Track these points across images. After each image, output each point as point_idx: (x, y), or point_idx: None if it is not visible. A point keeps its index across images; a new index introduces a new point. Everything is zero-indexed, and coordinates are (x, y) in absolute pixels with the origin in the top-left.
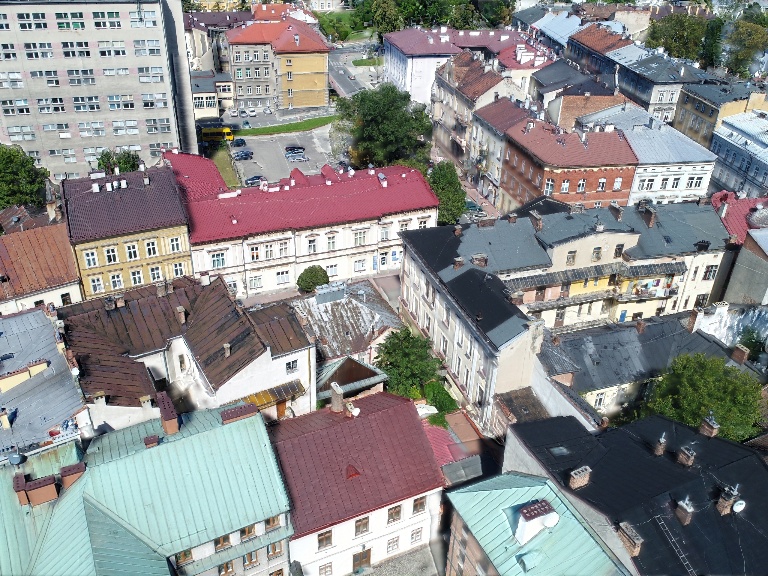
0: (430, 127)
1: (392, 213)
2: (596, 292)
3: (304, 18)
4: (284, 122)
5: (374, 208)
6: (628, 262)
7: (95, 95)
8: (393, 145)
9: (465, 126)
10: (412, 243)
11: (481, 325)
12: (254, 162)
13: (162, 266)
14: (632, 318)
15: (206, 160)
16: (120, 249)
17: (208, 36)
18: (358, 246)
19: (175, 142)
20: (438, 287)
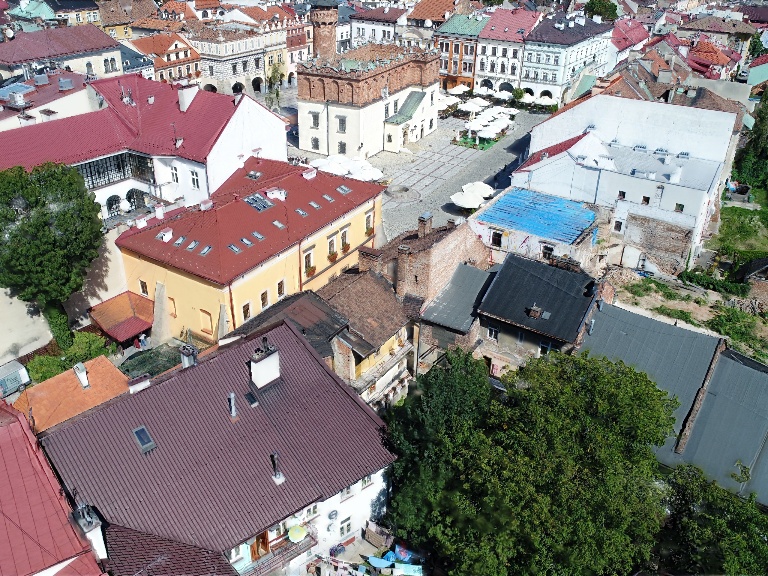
0: None
1: (8, 9)
2: None
3: None
4: None
5: None
6: None
7: None
8: None
9: None
10: (10, 1)
11: None
12: None
13: None
14: None
15: None
16: None
17: None
18: None
19: None
20: None
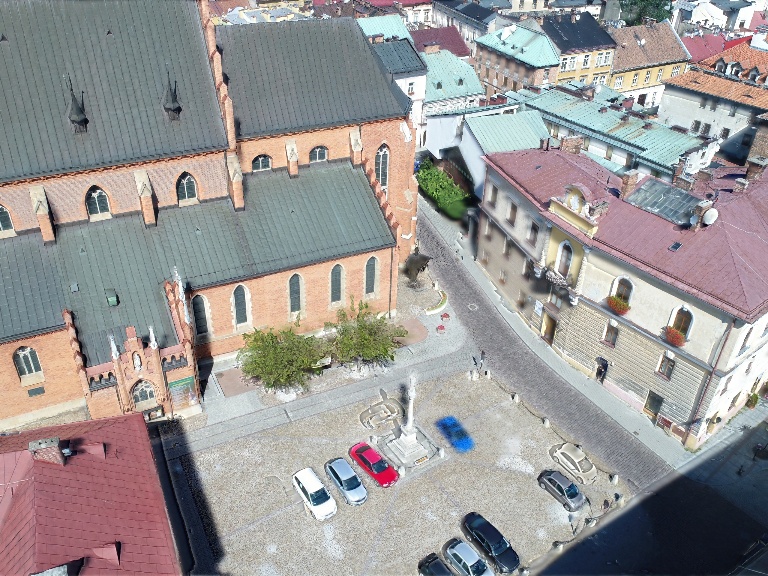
0: None
1: (420, 3)
2: None
3: None
4: None
5: (410, 0)
6: (551, 9)
7: None
8: None
9: None
10: (439, 1)
11: (479, 19)
12: None
13: None
14: None
15: None
16: None
17: None
18: None
19: None
20: (455, 15)
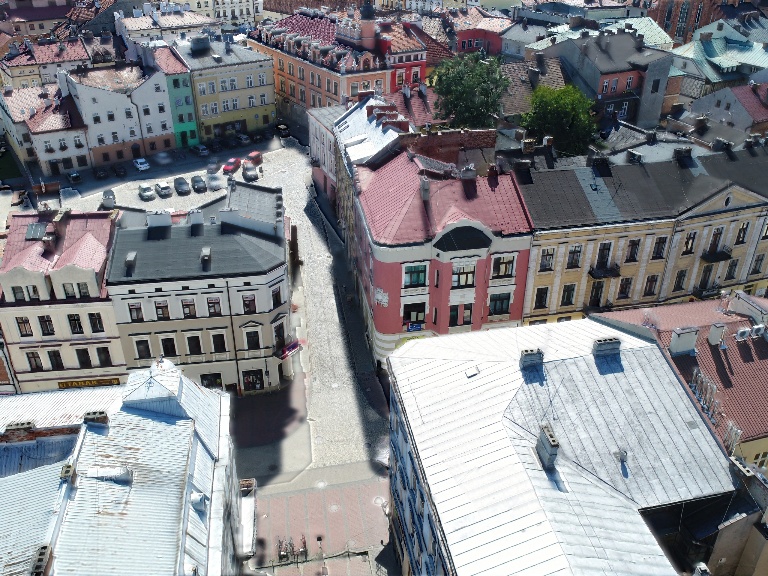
0: None
1: None
2: None
3: None
4: None
5: None
6: None
7: None
8: None
9: None
10: None
11: None
12: None
13: None
14: None
15: None
16: None
17: None
18: None
19: None
20: None
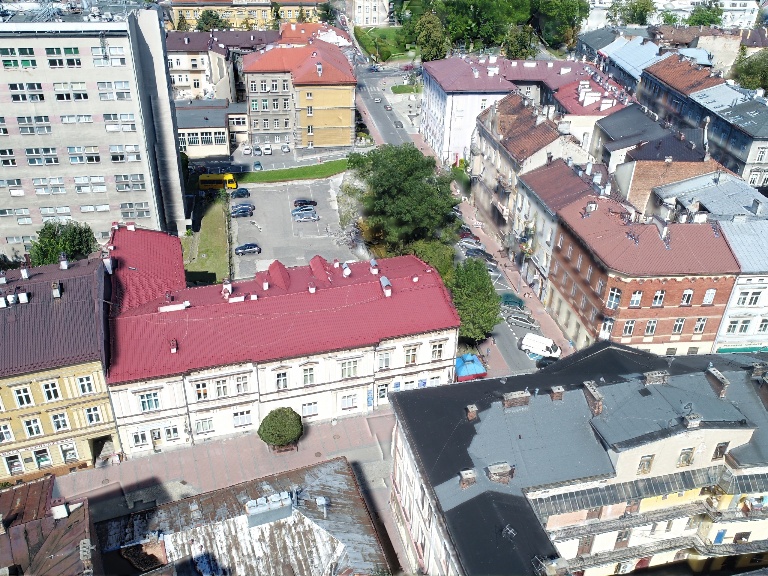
0: (460, 201)
1: (394, 337)
2: (681, 508)
3: (336, 40)
4: (301, 164)
5: (369, 330)
6: (734, 470)
7: (52, 146)
8: (410, 226)
9: (508, 191)
10: (405, 419)
11: None
12: (252, 222)
13: (69, 412)
14: (733, 539)
15: (171, 238)
16: (5, 394)
17: (226, 60)
18: (346, 378)
19: (151, 202)
20: None
